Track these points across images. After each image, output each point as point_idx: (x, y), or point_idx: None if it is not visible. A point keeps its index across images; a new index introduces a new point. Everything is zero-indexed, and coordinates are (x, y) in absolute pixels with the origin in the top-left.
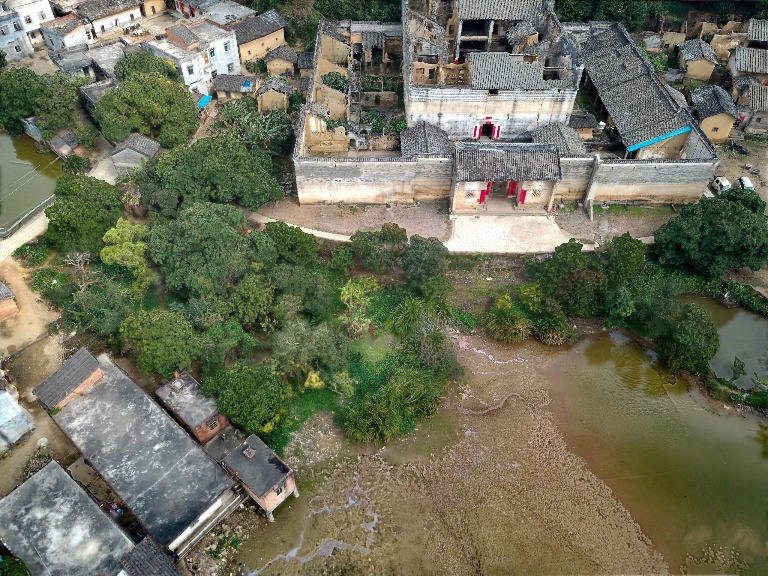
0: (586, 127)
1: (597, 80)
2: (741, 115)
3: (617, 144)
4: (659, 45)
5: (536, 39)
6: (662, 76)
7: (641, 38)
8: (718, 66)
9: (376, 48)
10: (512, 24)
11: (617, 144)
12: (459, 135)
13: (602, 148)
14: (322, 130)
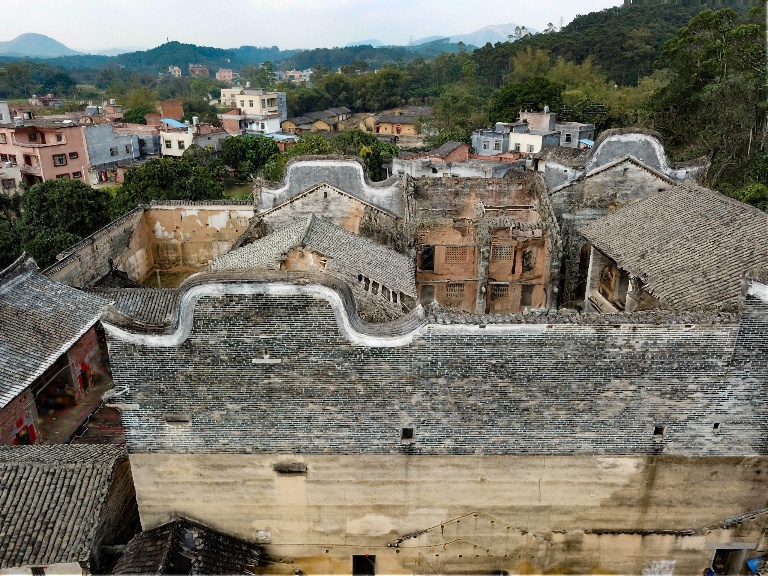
0: None
1: None
2: None
3: None
4: None
5: None
6: None
7: None
8: None
9: None
10: None
11: None
12: None
13: None
14: None
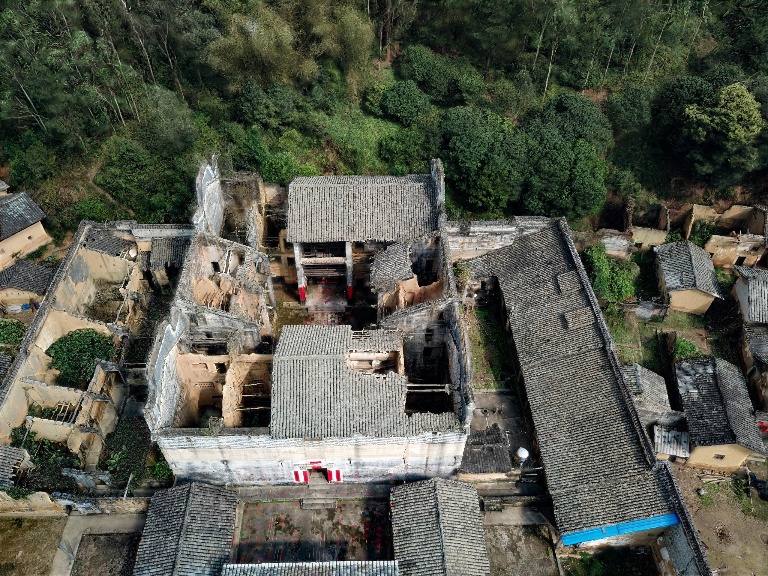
0: (491, 472)
1: (521, 339)
2: (762, 423)
3: (547, 499)
4: (626, 248)
5: (414, 284)
6: (630, 310)
7: (598, 238)
8: (718, 280)
9: (173, 266)
10: (381, 245)
11: (547, 499)
12: (270, 479)
13: (521, 503)
14: (5, 498)
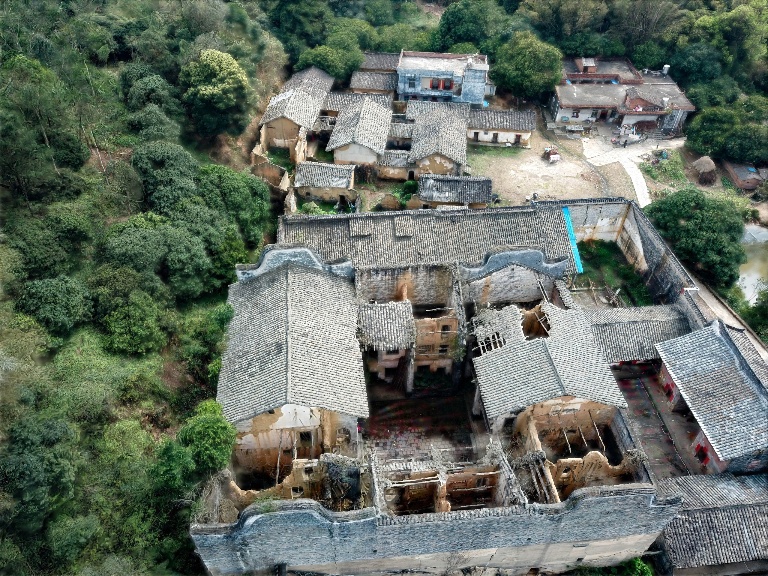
0: None
1: None
2: None
3: None
4: (294, 201)
5: None
6: None
7: None
8: None
9: None
10: None
11: None
12: None
13: None
14: None
